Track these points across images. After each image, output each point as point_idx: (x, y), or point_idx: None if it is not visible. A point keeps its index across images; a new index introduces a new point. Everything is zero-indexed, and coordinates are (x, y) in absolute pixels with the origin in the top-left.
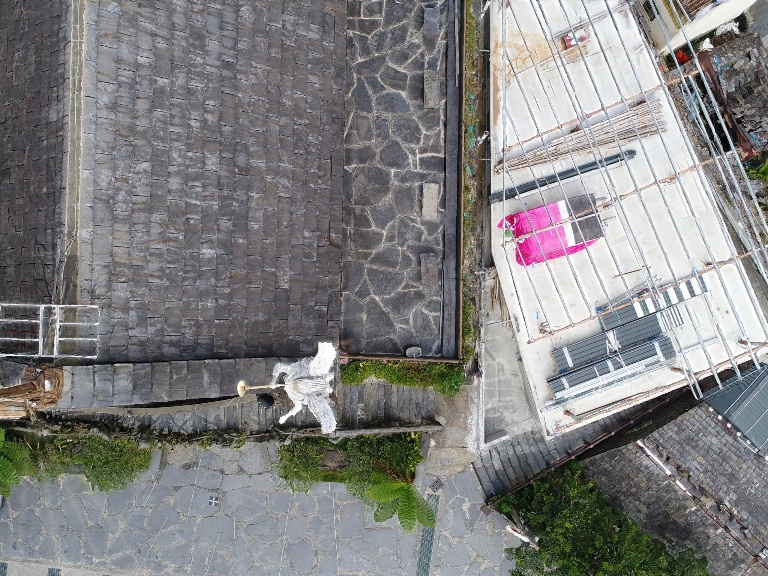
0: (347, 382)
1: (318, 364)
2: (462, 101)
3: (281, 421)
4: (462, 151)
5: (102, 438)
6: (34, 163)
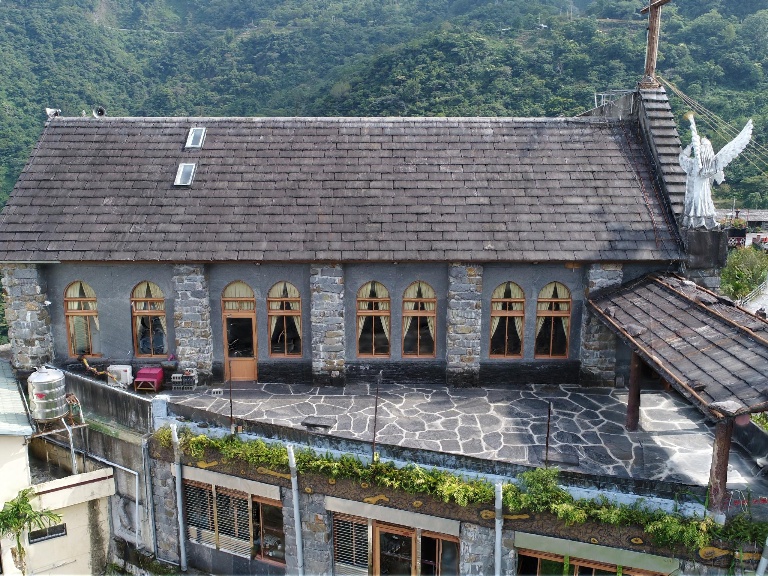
0: None
1: None
2: None
3: None
4: None
5: None
6: (519, 146)
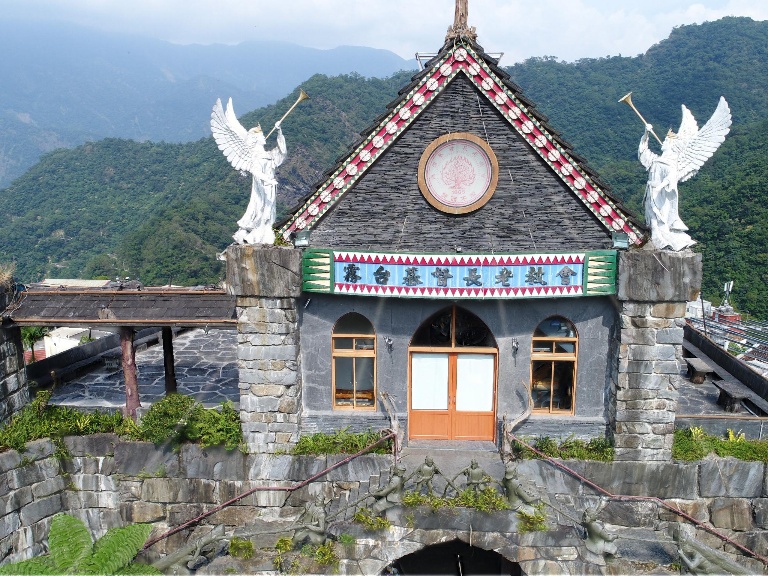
0: (680, 454)
1: (683, 135)
2: (692, 329)
3: (657, 188)
4: (711, 341)
5: (291, 572)
6: None
